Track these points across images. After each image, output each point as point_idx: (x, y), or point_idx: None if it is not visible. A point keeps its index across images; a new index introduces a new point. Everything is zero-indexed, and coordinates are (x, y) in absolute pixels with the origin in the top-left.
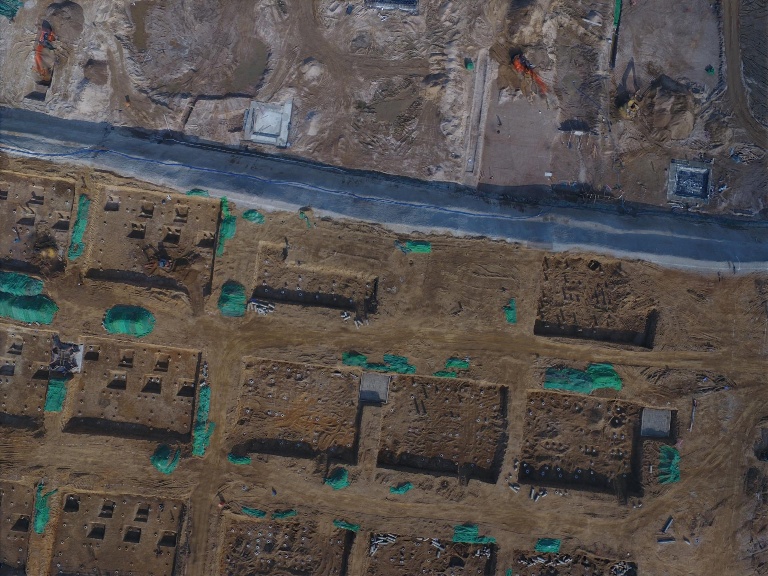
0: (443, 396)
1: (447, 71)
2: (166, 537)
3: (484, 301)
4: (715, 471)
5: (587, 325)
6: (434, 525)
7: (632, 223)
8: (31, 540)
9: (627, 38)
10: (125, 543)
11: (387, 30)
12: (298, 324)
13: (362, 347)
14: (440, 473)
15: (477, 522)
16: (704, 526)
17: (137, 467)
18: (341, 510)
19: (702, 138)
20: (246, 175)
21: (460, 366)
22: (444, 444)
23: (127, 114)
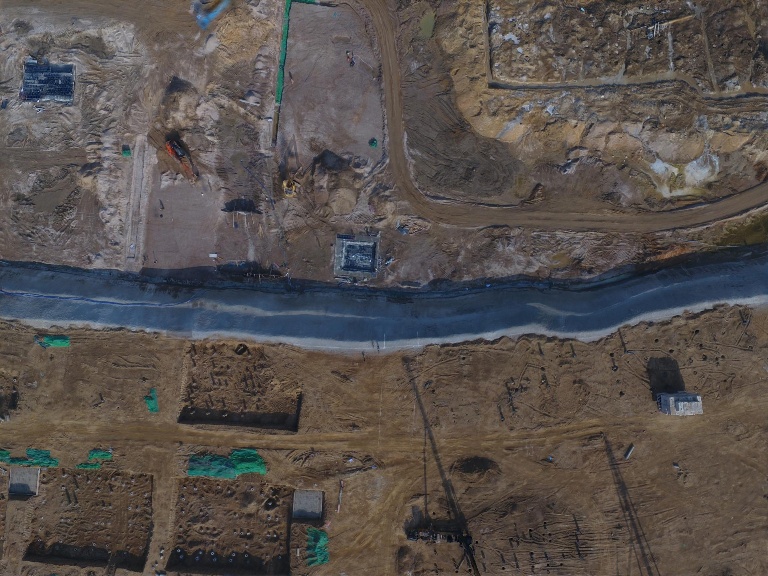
0: (94, 485)
1: (102, 160)
2: None
3: (125, 392)
4: (365, 551)
5: (236, 409)
6: None
7: (288, 303)
8: None
9: (288, 116)
10: None
11: (43, 122)
12: None
13: (5, 442)
14: (88, 563)
15: None
16: None
17: None
18: None
19: (366, 212)
20: None
21: (103, 457)
22: (96, 533)
23: None
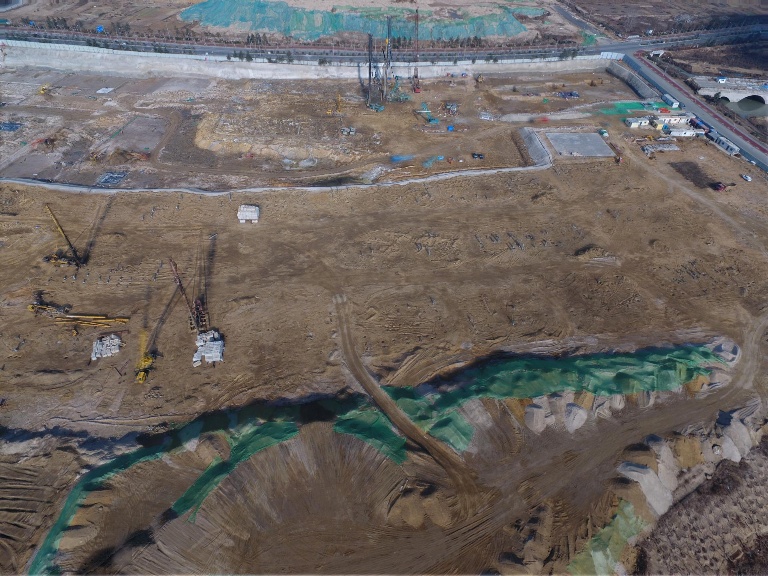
0: None
1: None
2: None
3: None
4: (9, 266)
5: None
6: None
7: None
8: None
9: None
10: None
11: None
12: None
13: None
14: None
15: None
16: None
17: None
18: None
19: None
20: None
21: None
22: None
23: None
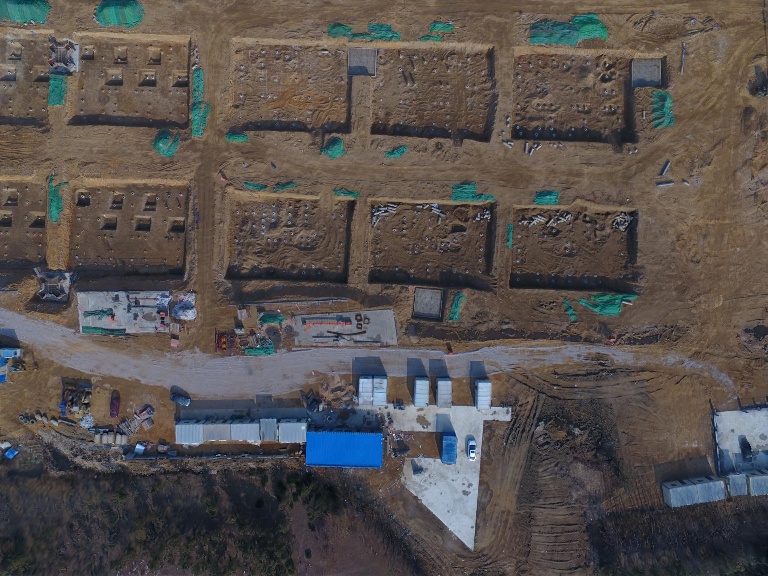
0: (430, 66)
1: None
2: (175, 227)
3: None
4: (710, 113)
5: None
6: (432, 186)
7: None
8: (48, 228)
9: None
10: (137, 232)
11: None
12: (281, 2)
13: (346, 19)
14: (434, 137)
15: (474, 180)
16: (703, 167)
17: (140, 153)
18: (340, 179)
19: None
20: None
21: (444, 29)
22: (436, 113)
23: None
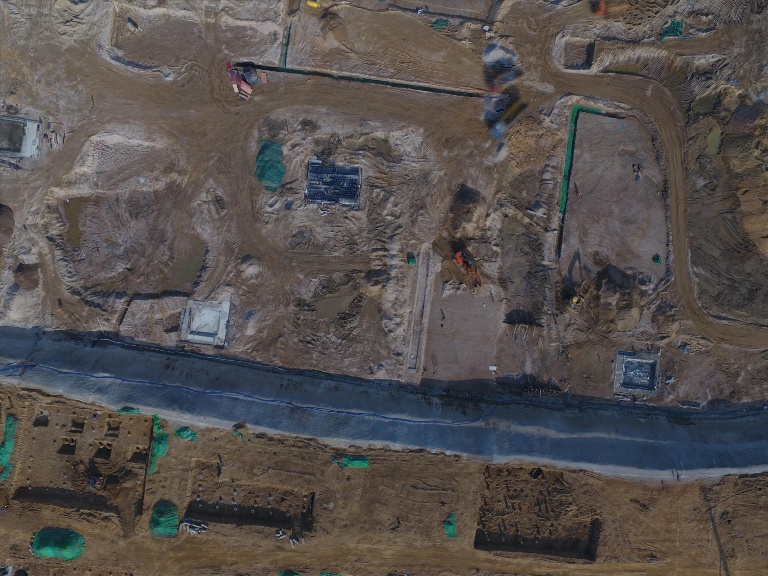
0: None
1: (388, 268)
2: None
3: (423, 516)
4: None
5: (529, 534)
6: None
7: (576, 423)
8: None
9: (573, 228)
10: None
11: (327, 225)
12: (232, 543)
13: (298, 565)
14: None
15: None
16: None
17: None
18: None
19: (649, 329)
20: (180, 386)
21: None
22: None
23: (59, 318)
